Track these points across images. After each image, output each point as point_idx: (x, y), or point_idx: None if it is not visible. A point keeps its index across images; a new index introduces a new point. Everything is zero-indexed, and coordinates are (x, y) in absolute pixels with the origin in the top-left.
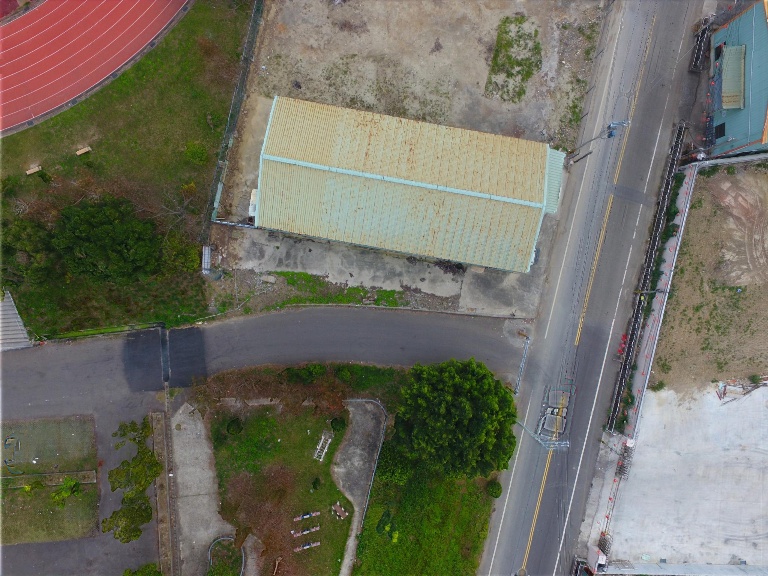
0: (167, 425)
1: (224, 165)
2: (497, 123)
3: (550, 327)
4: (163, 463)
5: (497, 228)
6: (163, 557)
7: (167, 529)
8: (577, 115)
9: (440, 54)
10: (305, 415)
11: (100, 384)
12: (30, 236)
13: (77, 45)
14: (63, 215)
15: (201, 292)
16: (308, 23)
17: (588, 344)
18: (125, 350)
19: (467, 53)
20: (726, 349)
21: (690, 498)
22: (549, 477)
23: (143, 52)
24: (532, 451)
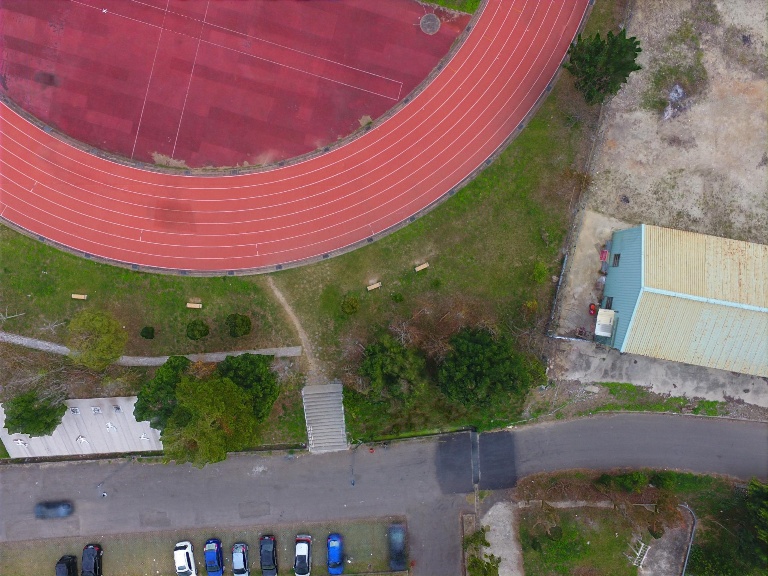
0: (476, 526)
1: (560, 281)
2: None
3: None
4: None
5: None
6: None
7: None
8: None
9: (767, 168)
10: (613, 518)
11: (413, 486)
12: (412, 365)
13: (416, 163)
14: (454, 348)
15: (523, 401)
16: (638, 139)
17: None
18: (437, 453)
19: None
20: None
21: None
22: None
23: (479, 169)
24: None
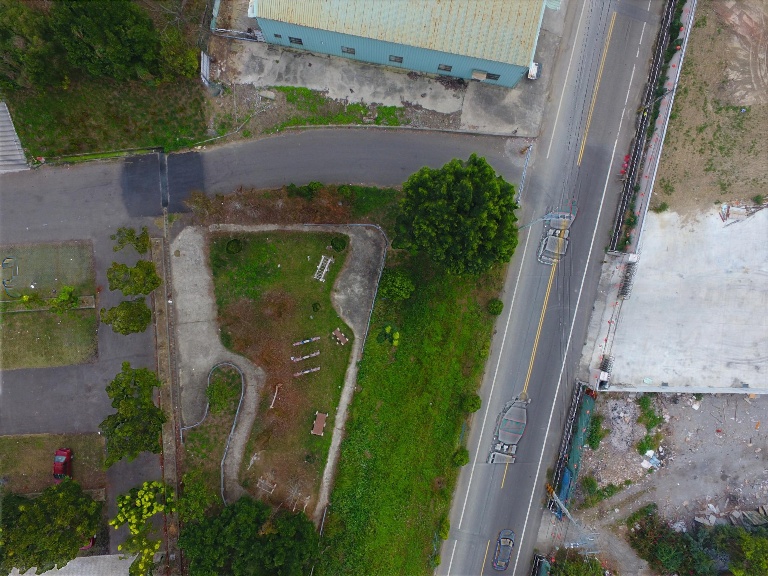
0: (166, 251)
1: None
2: None
3: (552, 147)
4: (162, 289)
5: (499, 17)
6: (162, 383)
7: (166, 355)
8: None
9: None
10: (305, 241)
11: (98, 209)
12: (26, 19)
13: None
14: None
15: (200, 109)
16: None
17: (590, 164)
18: (123, 174)
19: None
20: (730, 170)
21: (692, 321)
22: (551, 299)
23: None
24: (534, 273)
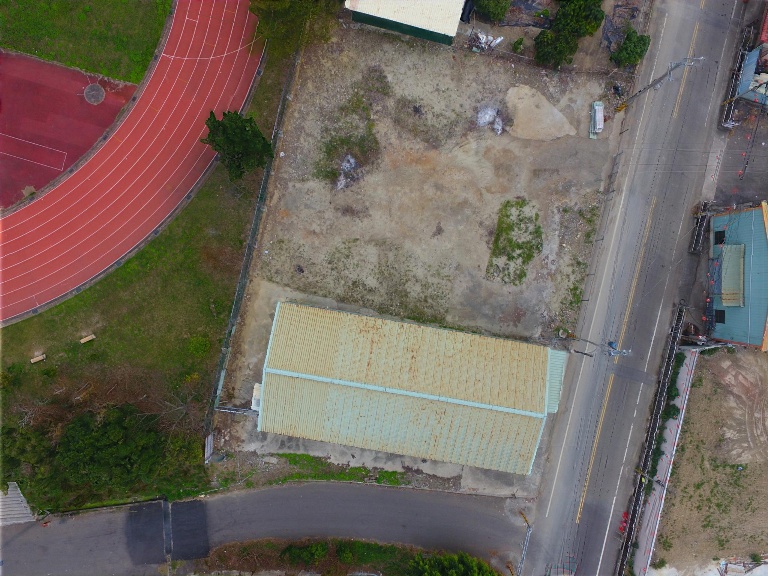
0: None
1: (227, 353)
2: (498, 305)
3: (551, 505)
4: None
5: (498, 435)
6: None
7: None
8: (578, 297)
9: (441, 238)
10: None
11: (102, 557)
12: (34, 447)
13: (82, 234)
14: (67, 432)
15: (204, 472)
16: (311, 208)
17: (589, 522)
18: (128, 523)
19: (468, 236)
20: (727, 527)
21: None
22: None
23: (147, 240)
24: None
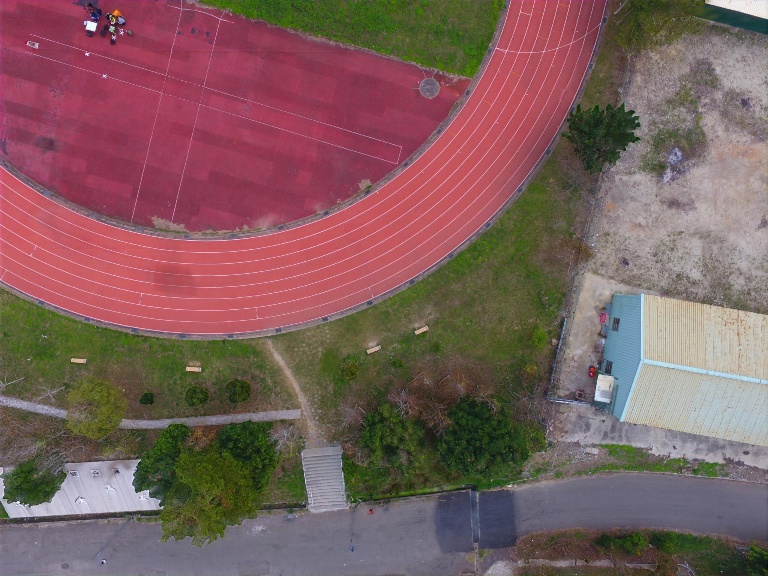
0: None
1: (560, 345)
2: None
3: None
4: None
5: None
6: None
7: None
8: None
9: (766, 230)
10: None
11: (412, 545)
12: (411, 436)
13: (416, 227)
14: (453, 421)
15: None
16: (637, 201)
17: None
18: (437, 512)
19: None
20: None
21: None
22: None
23: (478, 233)
24: None
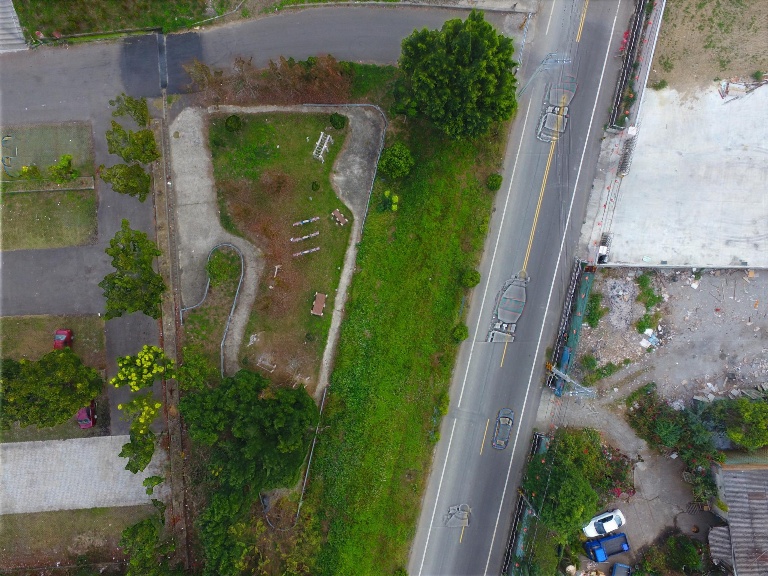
0: (165, 133)
1: None
2: None
3: (551, 23)
4: (161, 170)
5: None
6: (162, 264)
7: (166, 236)
8: None
9: None
10: (304, 122)
11: (97, 89)
12: None
13: None
14: None
15: None
16: None
17: (590, 41)
18: (122, 55)
19: None
20: (729, 47)
21: (691, 199)
22: (550, 177)
23: None
24: (533, 150)
